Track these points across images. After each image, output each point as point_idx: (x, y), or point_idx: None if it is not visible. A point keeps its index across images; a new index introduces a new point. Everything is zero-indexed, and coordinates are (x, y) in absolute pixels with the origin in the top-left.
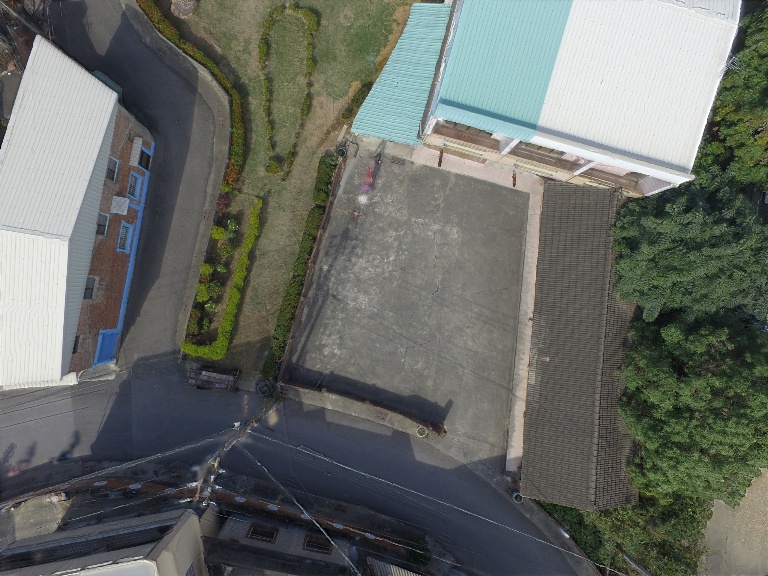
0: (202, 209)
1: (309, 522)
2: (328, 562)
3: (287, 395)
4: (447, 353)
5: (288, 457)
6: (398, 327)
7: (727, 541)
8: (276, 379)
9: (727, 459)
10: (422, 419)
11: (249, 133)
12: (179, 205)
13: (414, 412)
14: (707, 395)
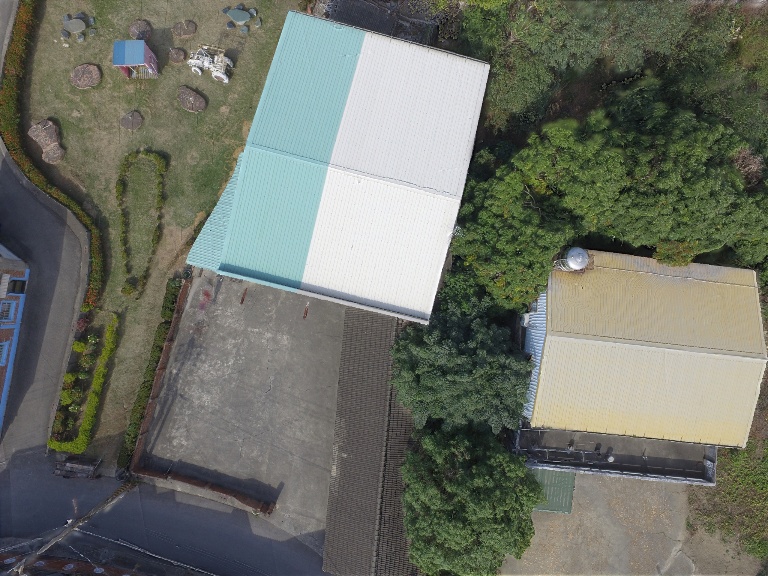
0: (70, 324)
1: None
2: None
3: (142, 480)
4: (278, 442)
5: (143, 532)
6: (236, 421)
7: None
8: (128, 469)
9: (459, 551)
10: (257, 499)
11: (109, 259)
12: (50, 321)
13: (251, 493)
14: (437, 501)
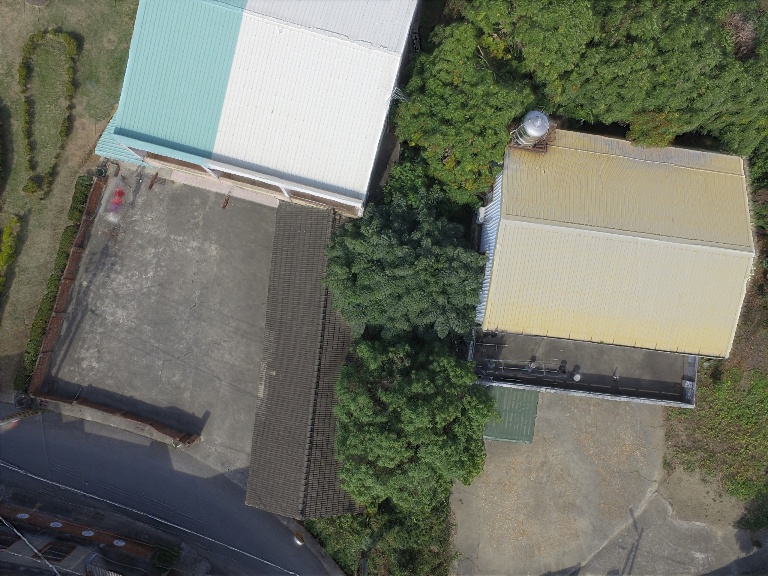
0: None
1: (54, 530)
2: (43, 569)
3: (46, 407)
4: (204, 366)
5: (46, 467)
6: (155, 341)
7: (479, 547)
8: (26, 392)
9: (396, 471)
10: (179, 430)
11: (11, 154)
12: None
13: (172, 423)
14: (369, 410)
